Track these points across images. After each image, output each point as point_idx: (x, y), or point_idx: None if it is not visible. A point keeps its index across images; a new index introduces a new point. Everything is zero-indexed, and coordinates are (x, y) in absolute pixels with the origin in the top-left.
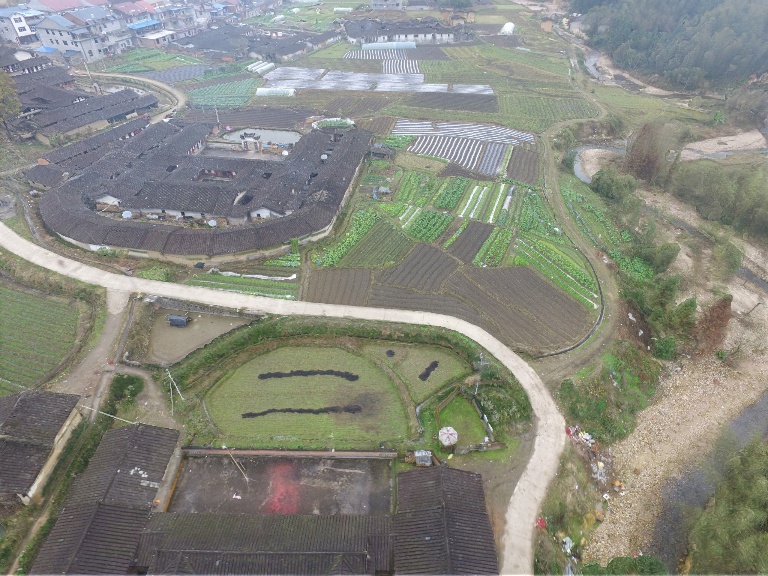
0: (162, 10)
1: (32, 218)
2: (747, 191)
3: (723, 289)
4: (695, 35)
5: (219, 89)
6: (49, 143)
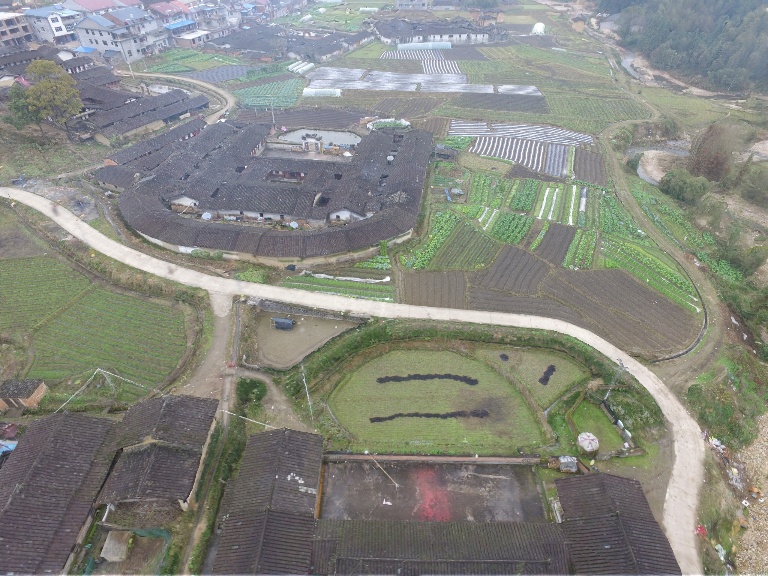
0: (196, 10)
1: (114, 219)
2: None
3: None
4: (740, 36)
5: (264, 89)
6: (109, 144)
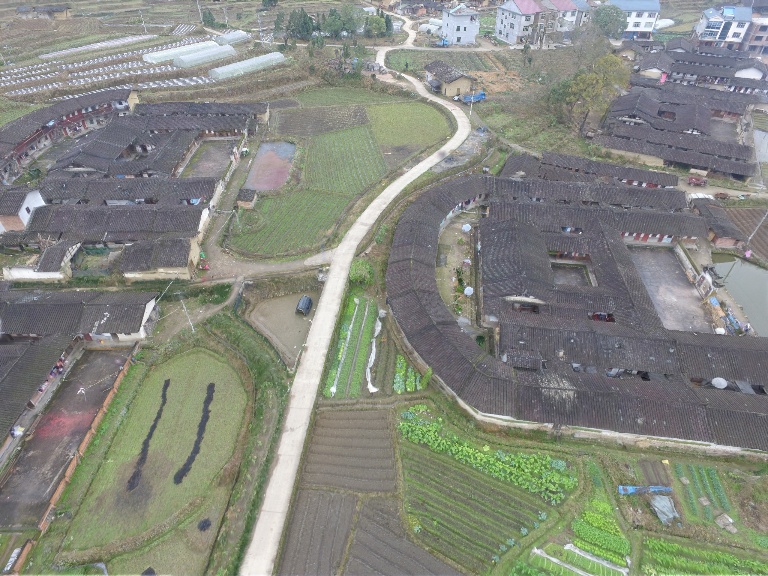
0: None
1: None
2: None
3: None
4: None
5: None
6: None
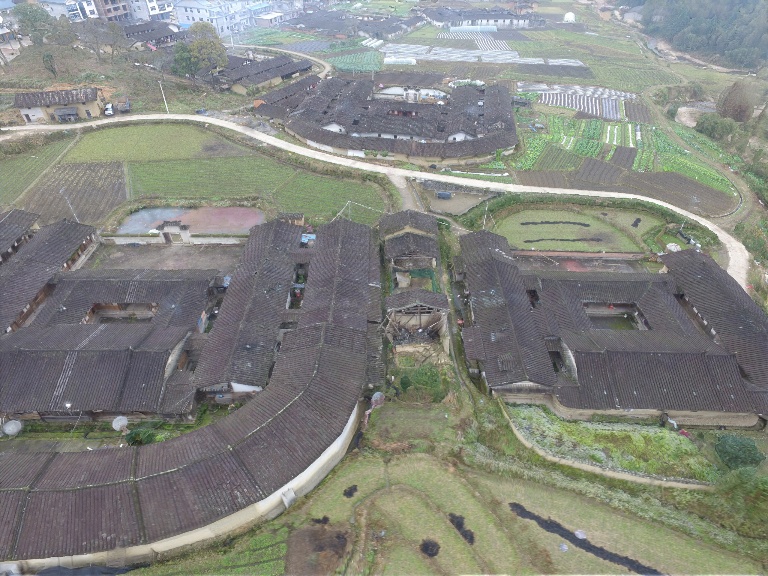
0: None
1: (289, 136)
2: None
3: None
4: (753, 20)
5: (349, 59)
6: (245, 92)
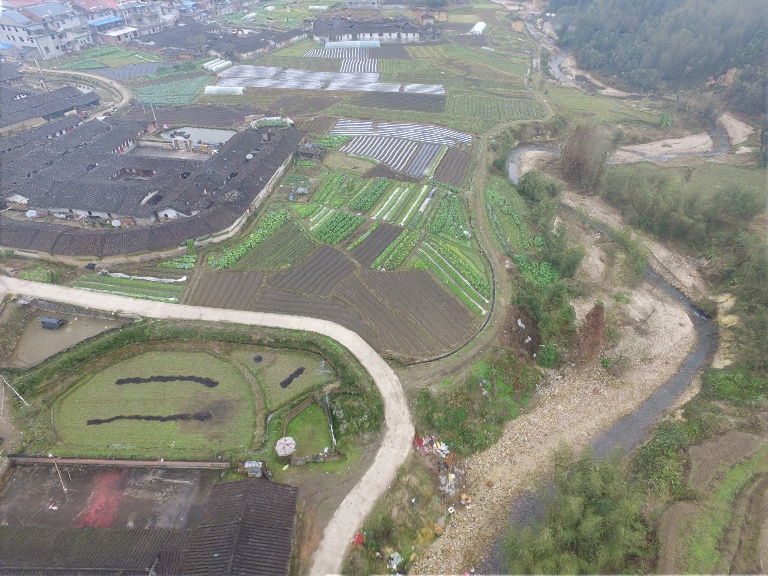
0: (126, 7)
1: None
2: (664, 195)
3: (627, 295)
4: (653, 36)
5: (169, 87)
6: None
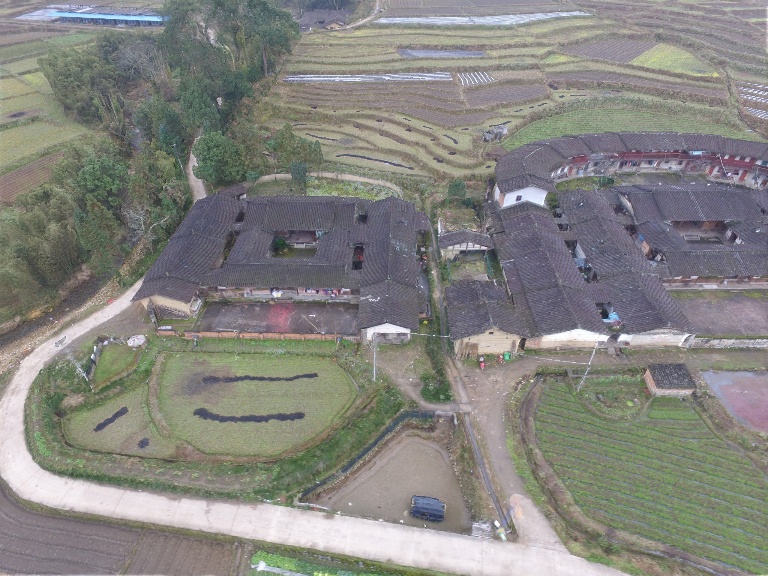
0: None
1: None
2: None
3: None
4: None
5: None
6: None
